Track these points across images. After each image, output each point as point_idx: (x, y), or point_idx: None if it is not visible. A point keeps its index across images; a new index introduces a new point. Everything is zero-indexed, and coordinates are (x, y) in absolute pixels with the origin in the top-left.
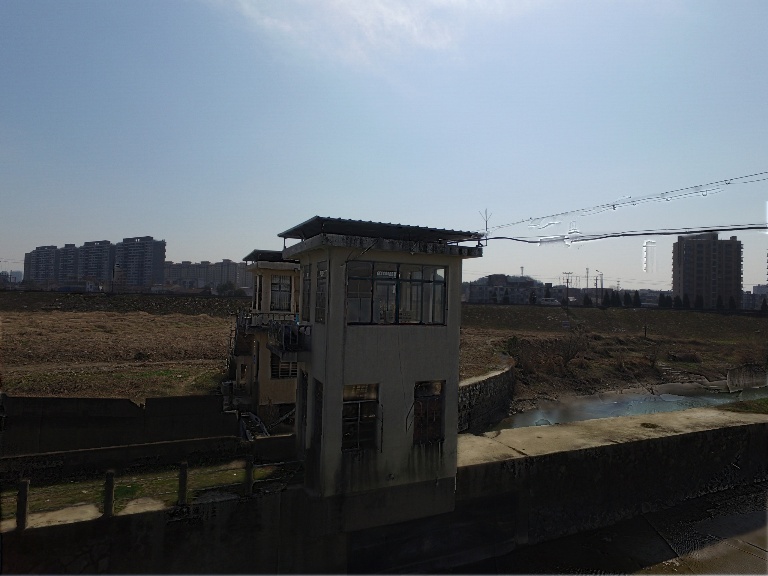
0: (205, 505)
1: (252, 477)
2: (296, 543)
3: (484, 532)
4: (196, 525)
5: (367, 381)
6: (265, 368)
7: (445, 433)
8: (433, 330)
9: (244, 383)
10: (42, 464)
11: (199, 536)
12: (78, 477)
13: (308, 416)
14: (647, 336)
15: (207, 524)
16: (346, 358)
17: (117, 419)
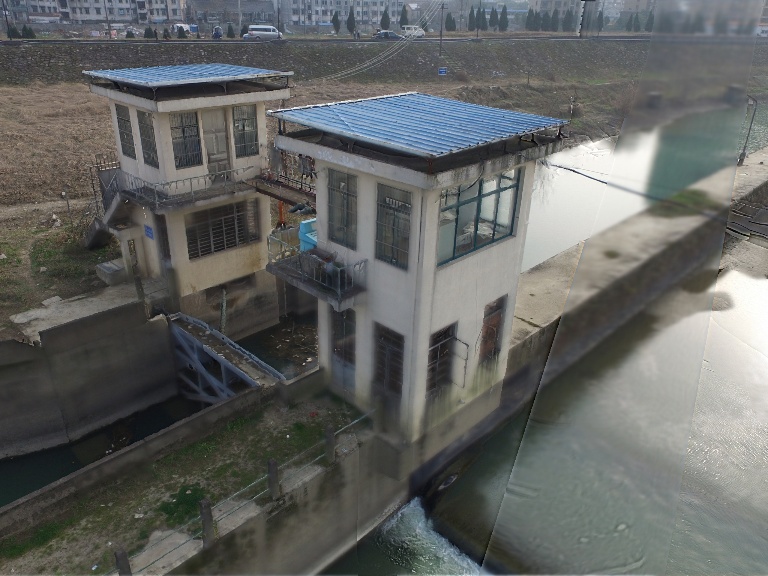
0: (298, 490)
1: (334, 446)
2: (372, 483)
3: (505, 406)
4: (292, 510)
5: (449, 322)
6: (182, 249)
7: (502, 344)
8: (505, 245)
9: (134, 263)
10: (51, 499)
11: (295, 517)
12: (105, 497)
13: (362, 358)
14: (530, 83)
15: (301, 504)
16: (434, 307)
17: (4, 368)
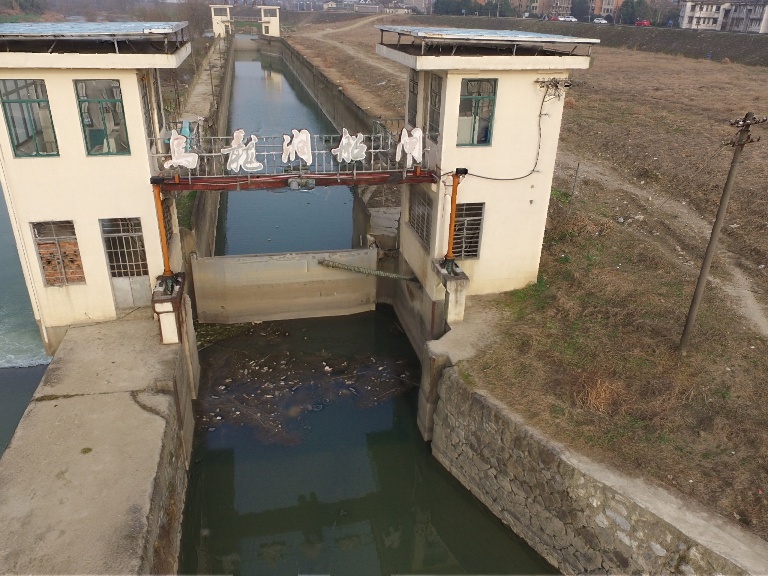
0: None
1: None
2: None
3: None
4: None
5: None
6: None
7: None
8: None
9: None
10: None
11: None
12: None
13: None
14: None
15: None
16: None
17: None
